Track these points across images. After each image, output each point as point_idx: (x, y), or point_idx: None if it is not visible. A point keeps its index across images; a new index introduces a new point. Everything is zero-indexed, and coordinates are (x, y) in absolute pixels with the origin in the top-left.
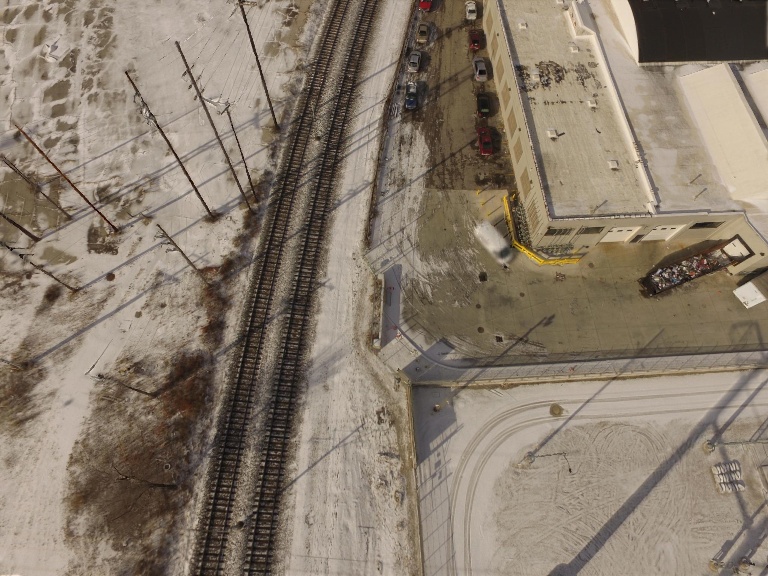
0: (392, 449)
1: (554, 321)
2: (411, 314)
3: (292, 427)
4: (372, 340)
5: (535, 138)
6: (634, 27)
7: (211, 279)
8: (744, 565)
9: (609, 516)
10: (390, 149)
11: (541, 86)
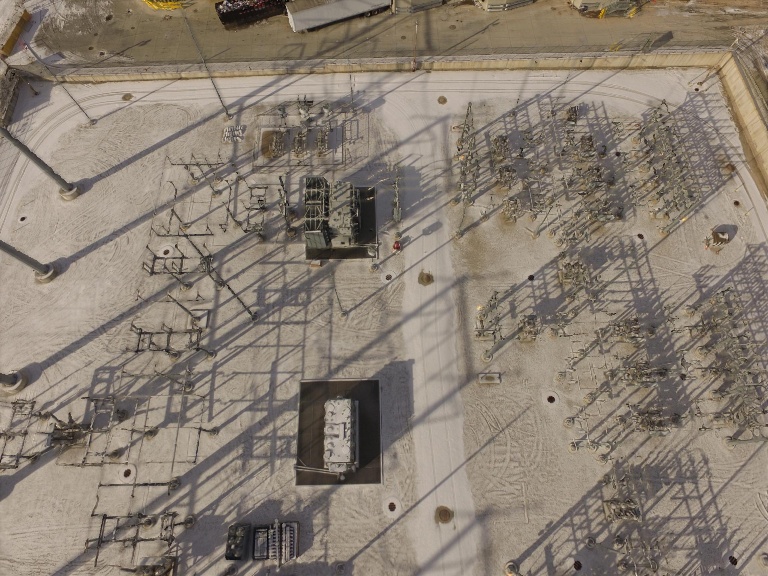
0: None
1: (149, 43)
2: (42, 37)
3: None
4: None
5: None
6: None
7: None
8: (216, 180)
9: (134, 154)
10: None
11: None
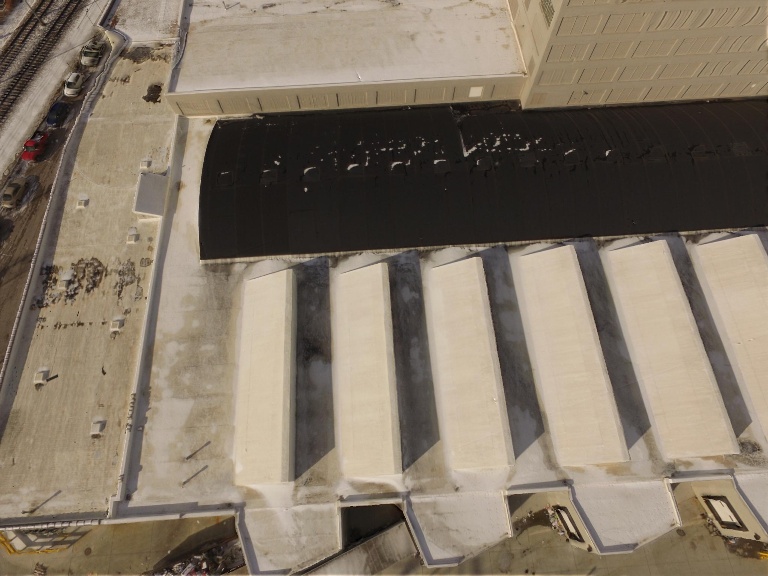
0: None
1: None
2: None
3: None
4: None
5: (15, 385)
6: (198, 213)
7: None
8: None
9: None
10: None
11: (63, 298)
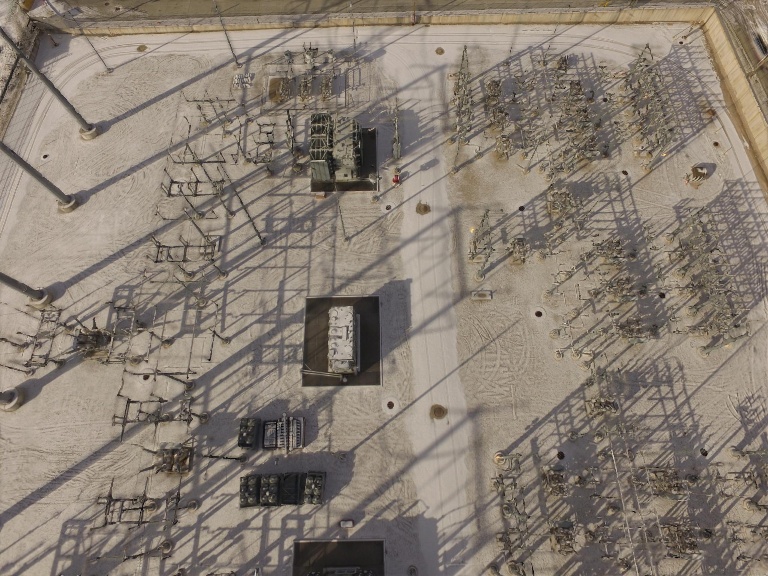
0: None
1: None
2: None
3: None
4: None
5: None
6: None
7: None
8: (226, 122)
9: (149, 99)
10: None
11: None
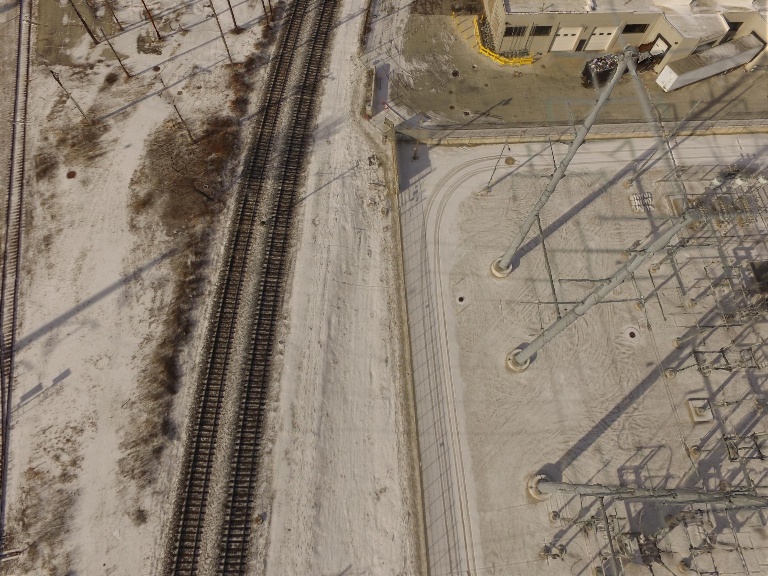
0: (380, 181)
1: (511, 102)
2: (397, 96)
3: (302, 166)
4: (365, 108)
5: None
6: None
7: (237, 71)
8: None
9: (547, 225)
10: None
11: None
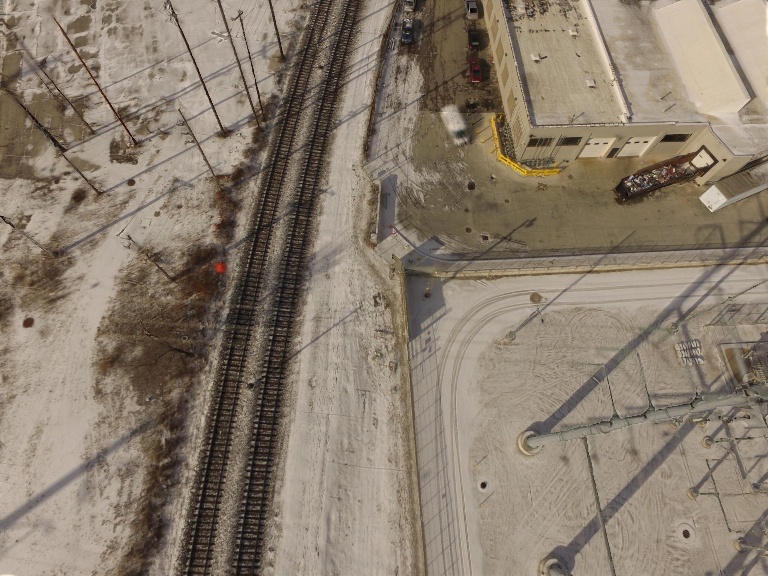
0: (387, 327)
1: (535, 223)
2: (405, 216)
3: (297, 308)
4: (369, 235)
5: (520, 60)
6: None
7: (223, 185)
8: (701, 423)
9: (581, 384)
10: (387, 77)
11: (527, 17)
